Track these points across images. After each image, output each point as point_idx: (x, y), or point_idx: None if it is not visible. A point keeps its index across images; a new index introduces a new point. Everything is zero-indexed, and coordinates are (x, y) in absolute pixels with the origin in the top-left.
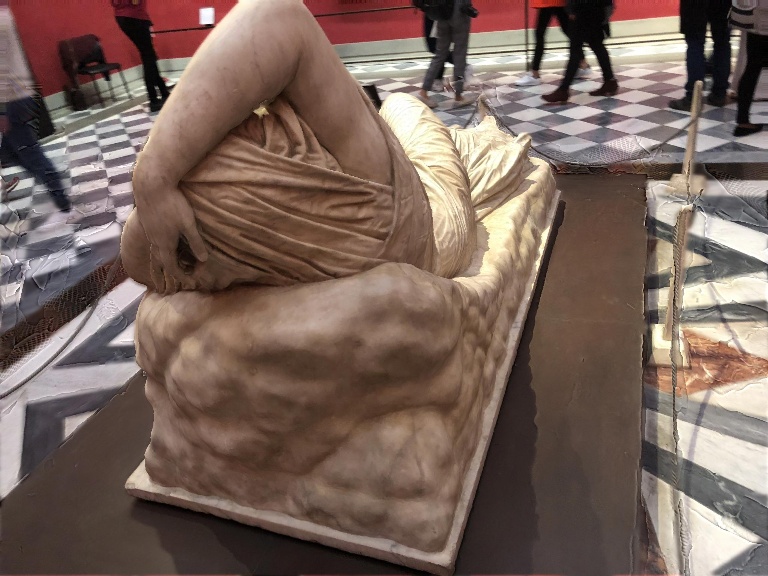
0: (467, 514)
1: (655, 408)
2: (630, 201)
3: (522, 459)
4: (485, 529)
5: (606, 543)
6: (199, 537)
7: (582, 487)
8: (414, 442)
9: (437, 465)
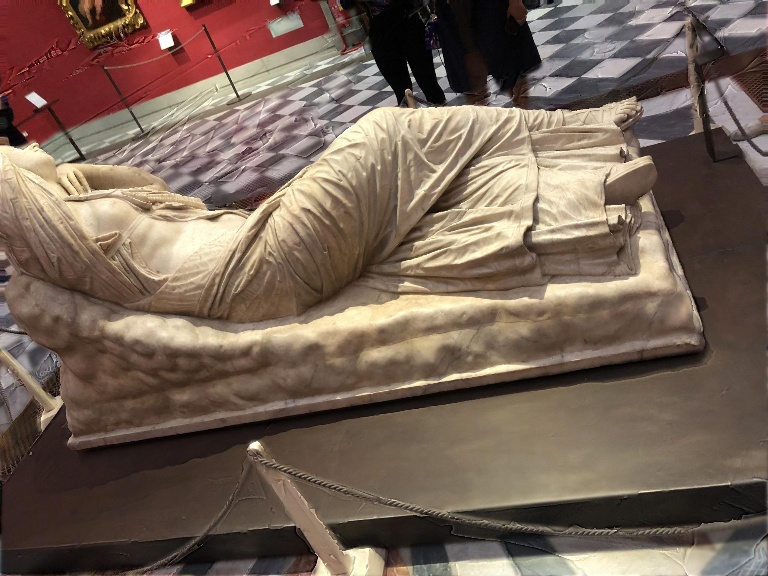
0: (105, 442)
1: (255, 572)
2: (736, 451)
3: (155, 462)
4: (111, 460)
5: (72, 526)
6: None
7: (120, 504)
8: (62, 376)
9: (68, 397)
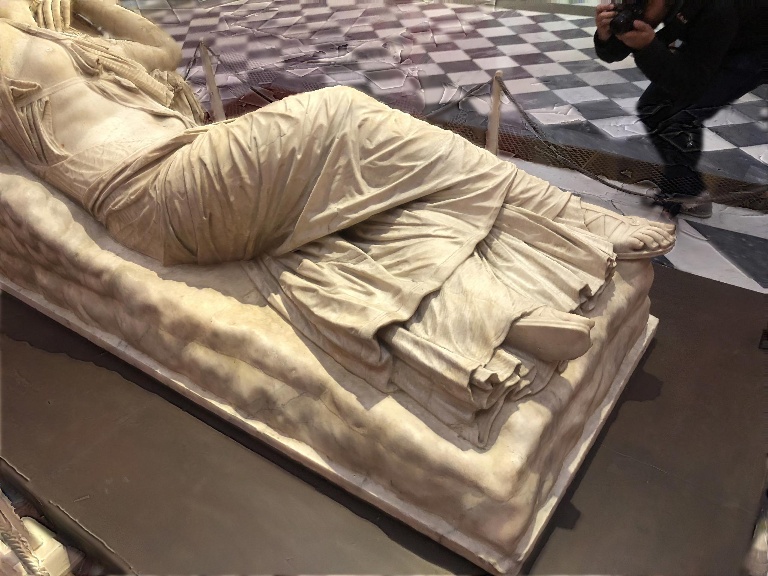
0: None
1: None
2: None
3: (2, 323)
4: None
5: None
6: None
7: None
8: None
9: None
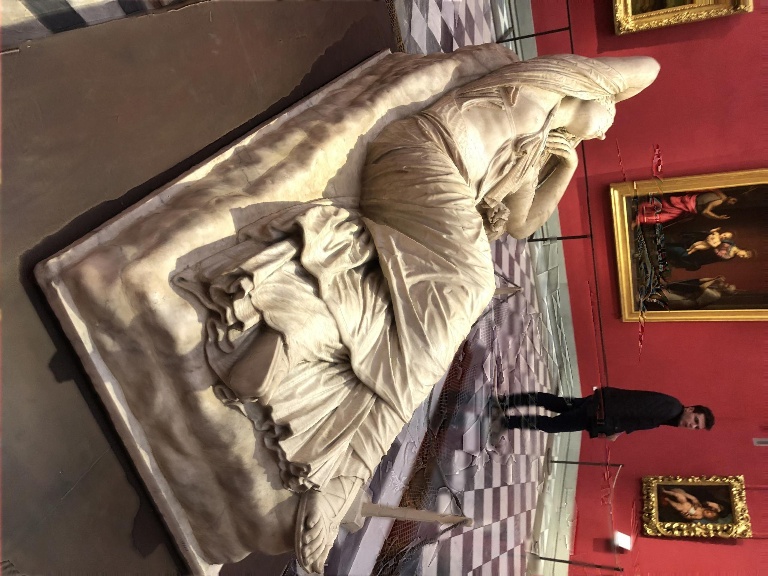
0: None
1: None
2: None
3: None
4: None
5: None
6: None
7: None
8: None
9: None
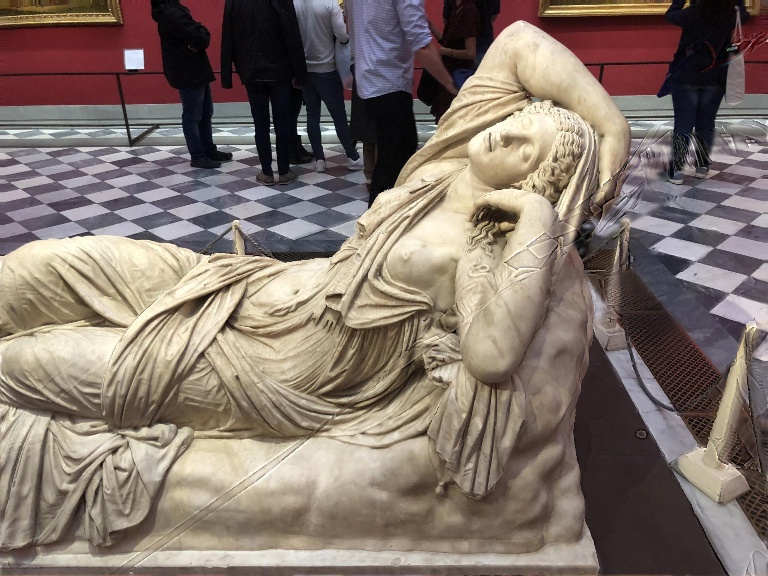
0: None
1: None
2: None
3: None
4: None
5: None
6: (588, 504)
7: None
8: None
9: None
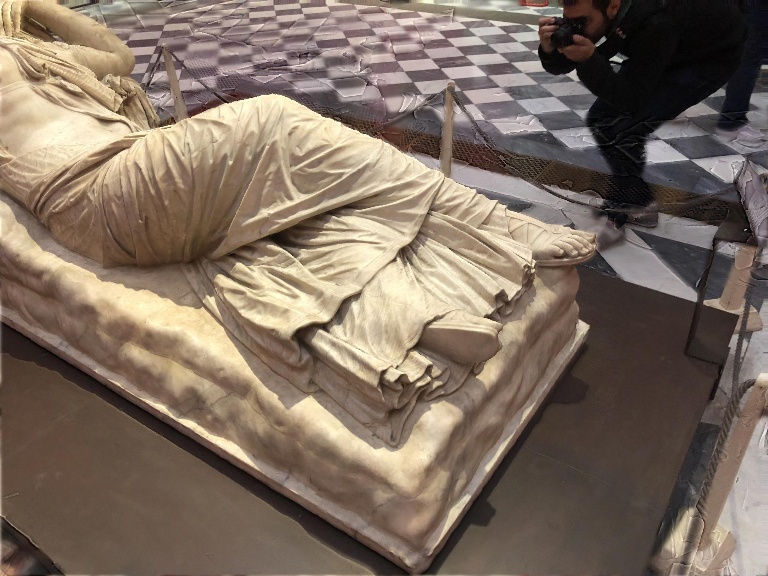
0: None
1: None
2: None
3: None
4: None
5: None
6: None
7: None
8: None
9: None
